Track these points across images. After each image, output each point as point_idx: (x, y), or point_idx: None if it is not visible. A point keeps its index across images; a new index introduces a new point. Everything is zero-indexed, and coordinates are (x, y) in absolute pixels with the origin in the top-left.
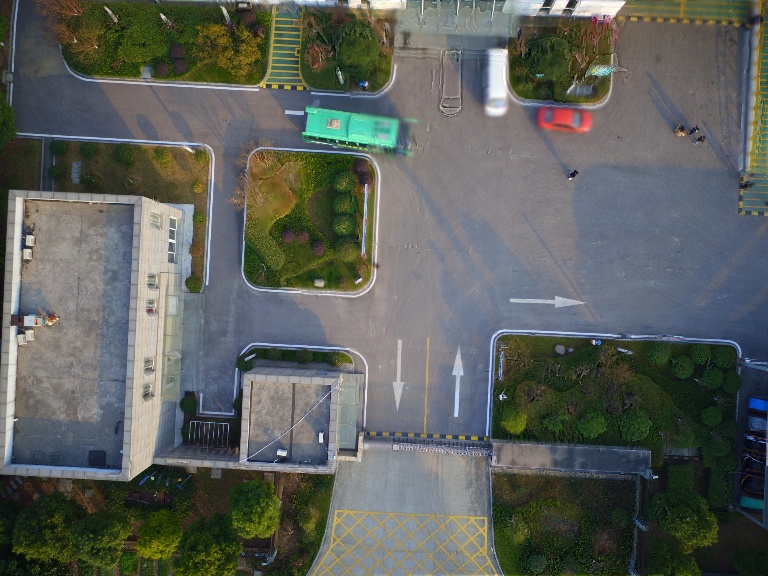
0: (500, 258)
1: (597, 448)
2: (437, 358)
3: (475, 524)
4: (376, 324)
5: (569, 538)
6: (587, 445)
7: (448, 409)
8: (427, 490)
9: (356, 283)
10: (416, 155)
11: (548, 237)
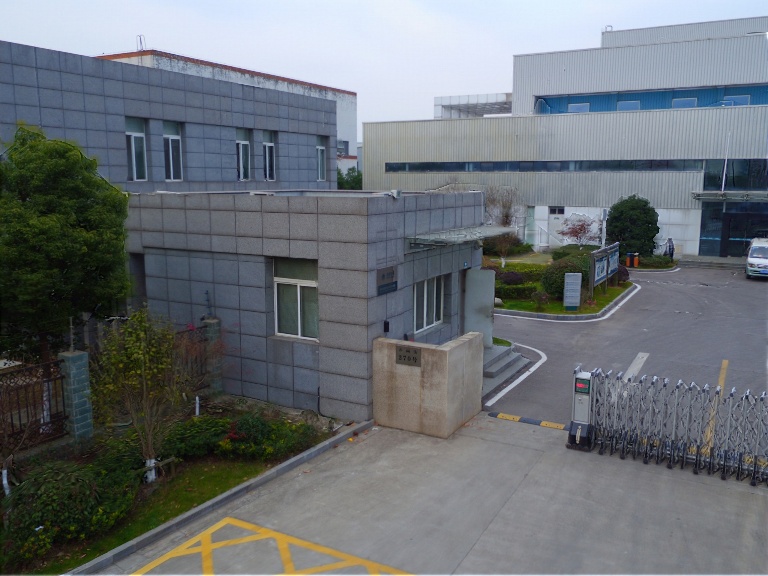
0: None
1: None
2: (753, 377)
3: None
4: (590, 338)
5: None
6: None
7: None
8: (711, 573)
9: (566, 292)
10: (705, 287)
11: None
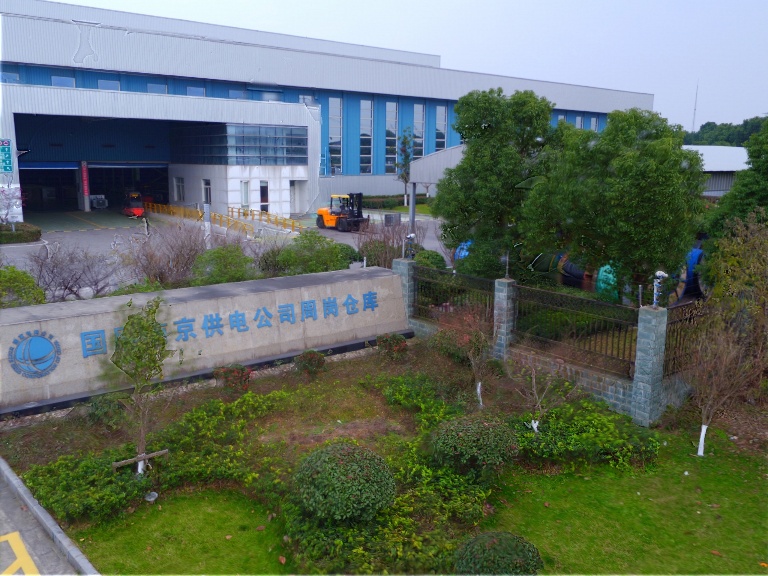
0: None
1: (264, 279)
2: None
3: None
4: None
5: None
6: None
7: None
8: None
9: None
10: None
11: None
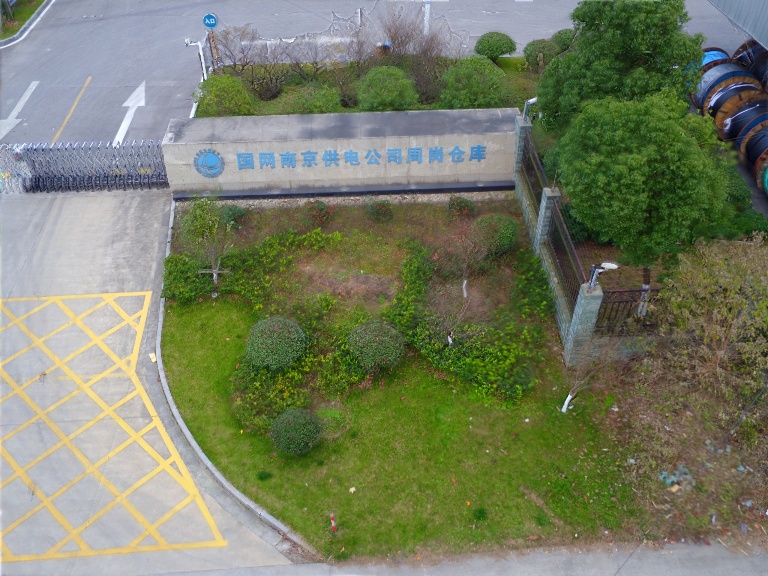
0: (230, 17)
1: (401, 111)
2: (99, 93)
3: (115, 308)
4: (0, 71)
5: (376, 309)
6: (379, 110)
7: (100, 140)
8: (4, 254)
9: None
10: None
11: (302, 2)
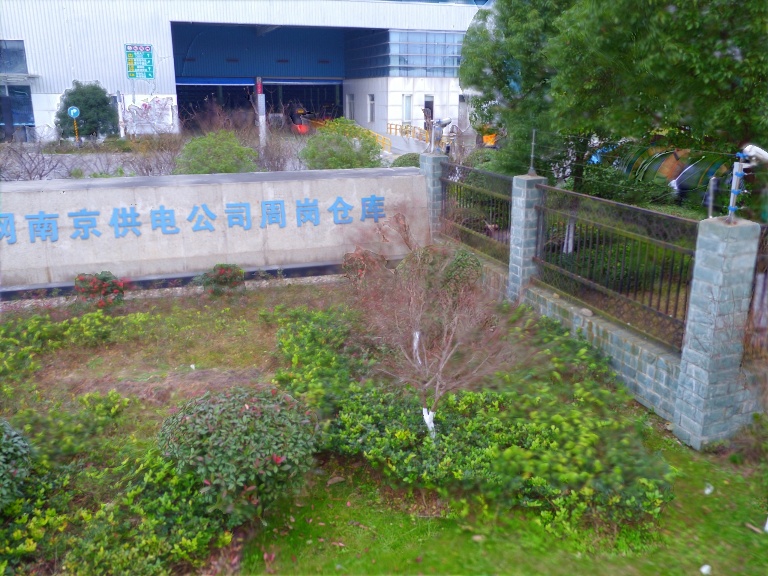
0: None
1: (243, 173)
2: None
3: None
4: None
5: None
6: None
7: None
8: None
9: None
10: None
11: None
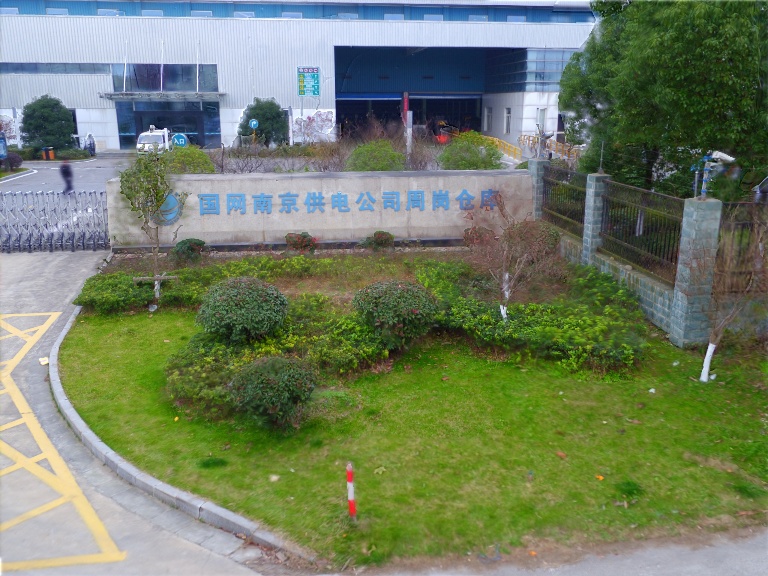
0: None
1: (395, 171)
2: None
3: (1, 325)
4: None
5: None
6: None
7: None
8: None
9: None
10: None
11: None
